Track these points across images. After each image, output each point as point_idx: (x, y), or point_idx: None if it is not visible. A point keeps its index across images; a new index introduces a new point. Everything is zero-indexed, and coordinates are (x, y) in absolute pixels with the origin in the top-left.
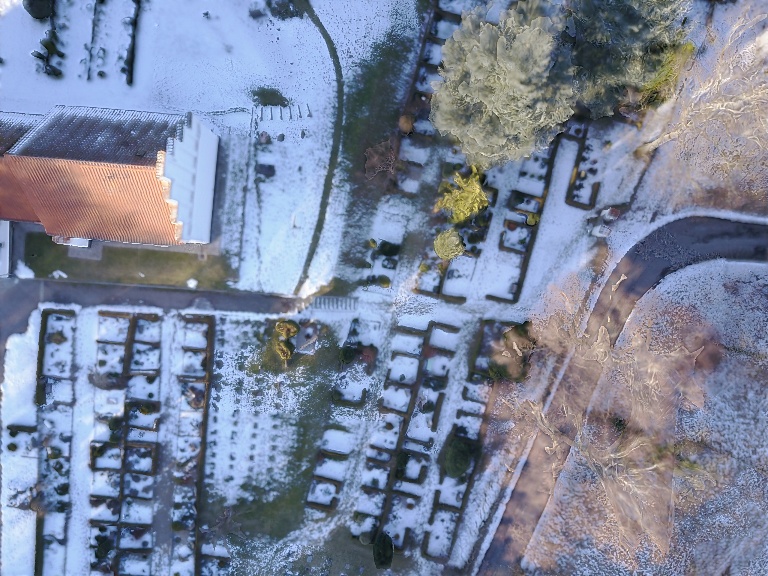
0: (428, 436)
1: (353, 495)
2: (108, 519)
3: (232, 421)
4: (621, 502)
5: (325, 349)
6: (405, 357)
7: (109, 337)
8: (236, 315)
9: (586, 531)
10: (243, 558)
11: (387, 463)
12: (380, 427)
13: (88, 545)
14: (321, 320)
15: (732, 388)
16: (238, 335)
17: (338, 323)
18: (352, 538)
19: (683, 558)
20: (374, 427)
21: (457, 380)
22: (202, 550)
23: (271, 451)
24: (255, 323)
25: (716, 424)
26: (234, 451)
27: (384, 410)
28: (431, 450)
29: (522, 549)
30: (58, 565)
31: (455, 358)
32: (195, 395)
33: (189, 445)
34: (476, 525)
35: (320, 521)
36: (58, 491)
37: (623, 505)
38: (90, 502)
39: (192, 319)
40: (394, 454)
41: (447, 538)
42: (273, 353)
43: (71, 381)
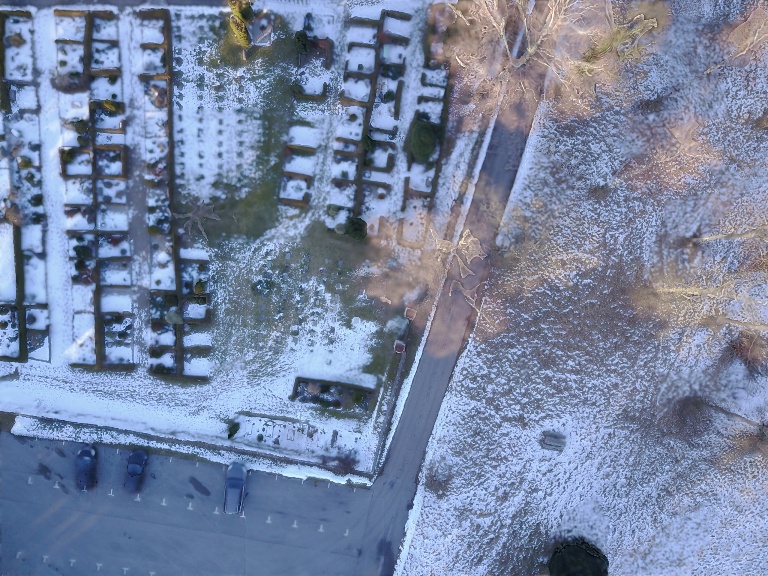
0: (392, 125)
1: (324, 189)
2: (84, 229)
3: (197, 118)
4: (565, 38)
5: (281, 40)
6: (361, 48)
7: (67, 37)
8: (190, 10)
9: (556, 201)
10: (222, 260)
11: (354, 152)
12: (344, 120)
13: (67, 258)
14: (274, 10)
15: (681, 43)
16: (194, 30)
17: (291, 15)
18: (327, 230)
19: (653, 218)
20: (338, 121)
21: (414, 67)
22: (180, 254)
23: (238, 147)
24: (210, 17)
25: (670, 80)
26: (202, 149)
27: (346, 100)
28: (396, 138)
29: (495, 227)
30: (39, 281)
31: (410, 46)
32: (158, 93)
33: (157, 146)
34: (448, 206)
35: (294, 218)
36: (32, 201)
37: (567, 39)
38: (65, 213)
39: (147, 12)
40: (360, 142)
41: (421, 223)
42: (230, 47)
43: (34, 87)
